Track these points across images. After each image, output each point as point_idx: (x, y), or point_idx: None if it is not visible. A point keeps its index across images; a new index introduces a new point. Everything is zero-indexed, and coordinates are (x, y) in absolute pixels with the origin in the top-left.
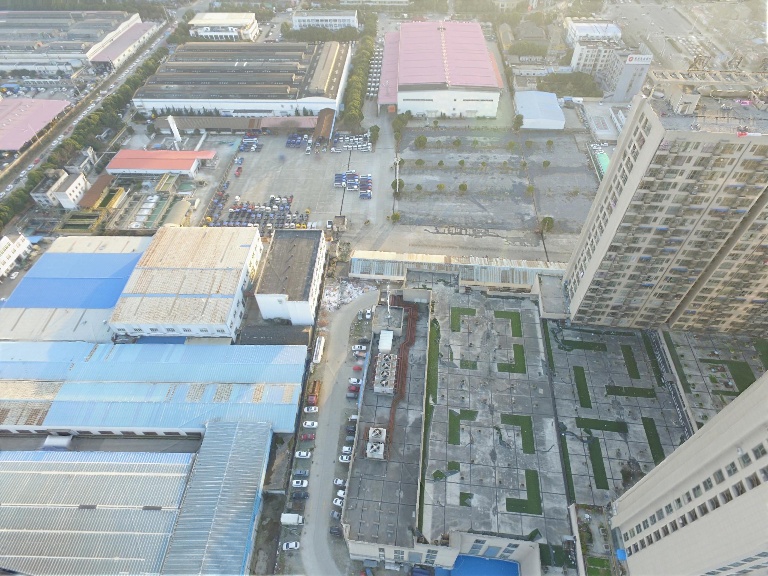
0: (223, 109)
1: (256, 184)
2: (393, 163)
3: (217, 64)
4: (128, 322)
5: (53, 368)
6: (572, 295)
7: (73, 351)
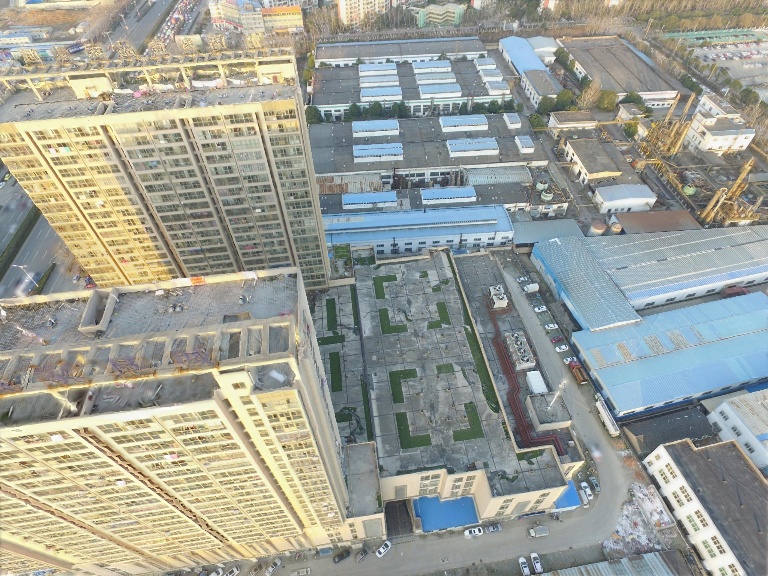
0: None
1: None
2: None
3: None
4: None
5: None
6: None
7: None
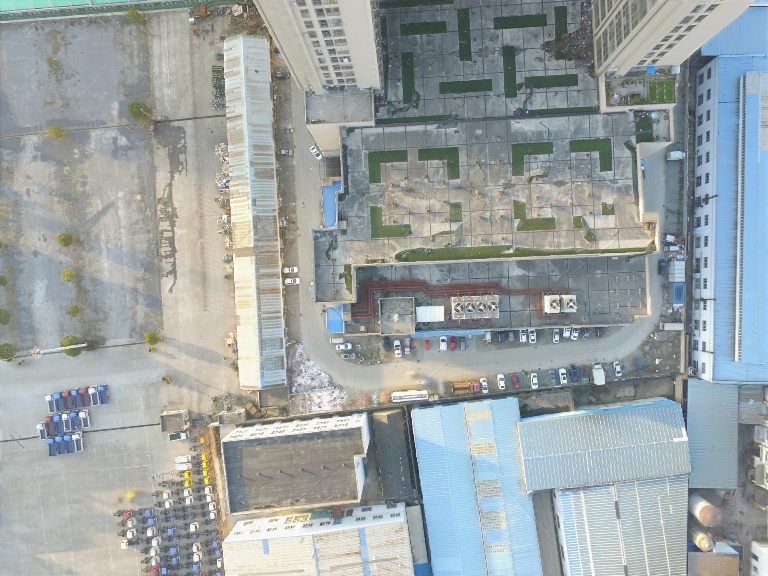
0: None
1: None
2: (7, 363)
3: None
4: None
5: None
6: (352, 81)
7: None
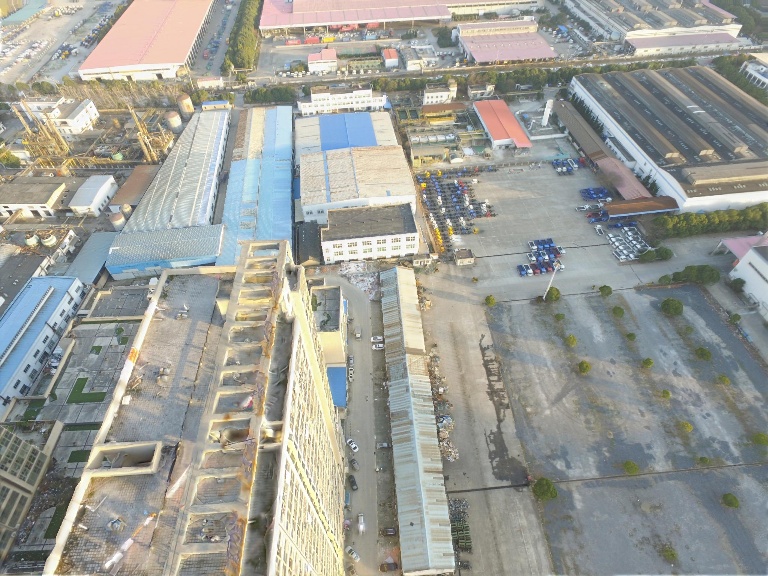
0: (610, 130)
1: (504, 187)
2: None
3: (678, 95)
4: (301, 162)
5: (271, 150)
6: None
7: (284, 153)
